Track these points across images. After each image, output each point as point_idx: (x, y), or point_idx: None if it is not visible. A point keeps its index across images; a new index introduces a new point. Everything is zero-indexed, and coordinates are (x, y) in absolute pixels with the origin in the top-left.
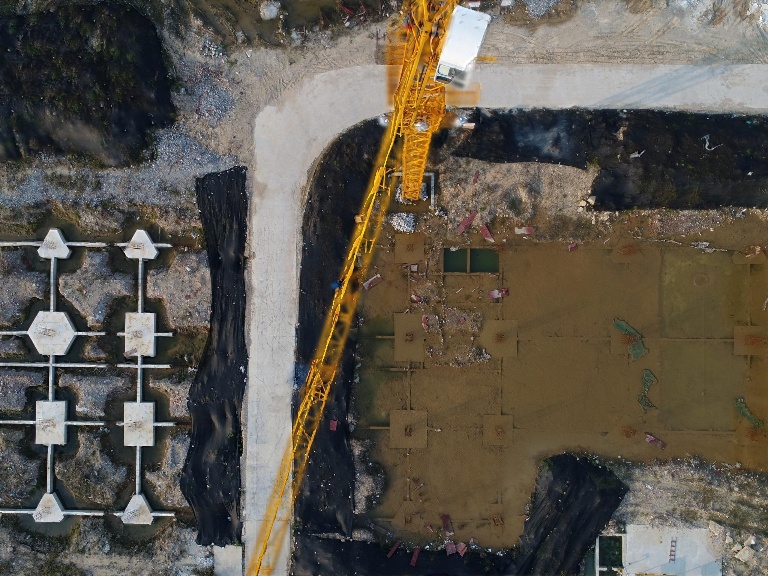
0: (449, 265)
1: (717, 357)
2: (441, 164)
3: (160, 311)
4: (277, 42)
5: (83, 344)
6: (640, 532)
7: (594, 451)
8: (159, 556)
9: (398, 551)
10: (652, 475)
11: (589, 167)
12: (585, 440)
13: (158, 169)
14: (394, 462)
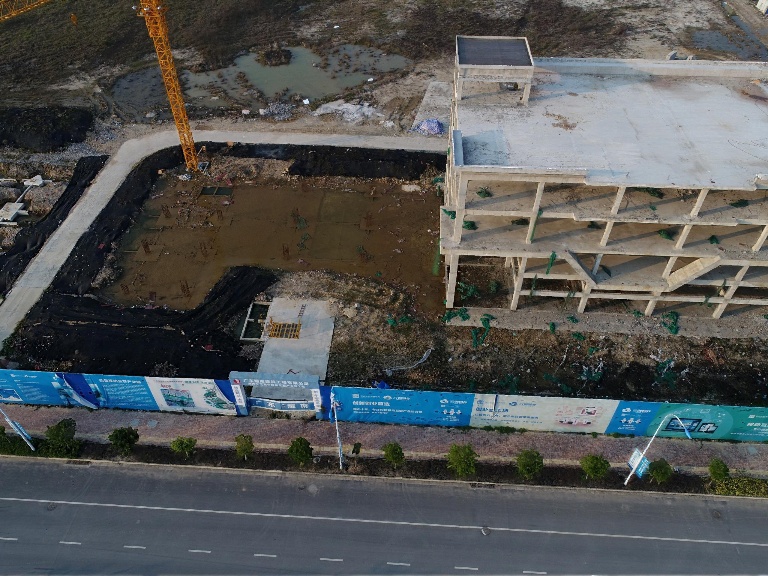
0: (204, 192)
1: (349, 230)
2: (213, 158)
3: (28, 206)
4: (150, 123)
5: None
6: (282, 301)
7: (263, 266)
8: None
9: None
10: (297, 275)
11: (290, 160)
12: (259, 261)
13: (64, 154)
14: (132, 267)
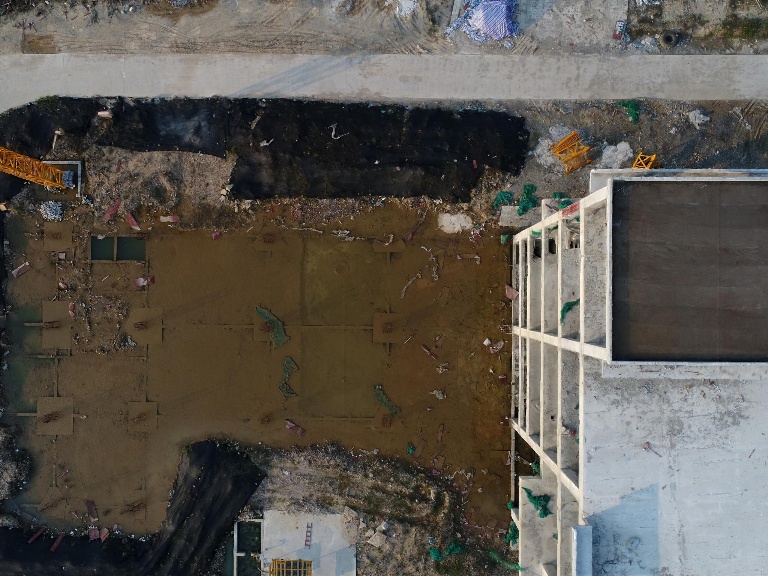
0: (96, 253)
1: (357, 344)
2: (85, 153)
3: None
4: None
5: None
6: (277, 518)
7: (236, 438)
8: None
9: (42, 537)
10: (290, 461)
11: (228, 156)
12: (227, 427)
13: None
14: (41, 448)
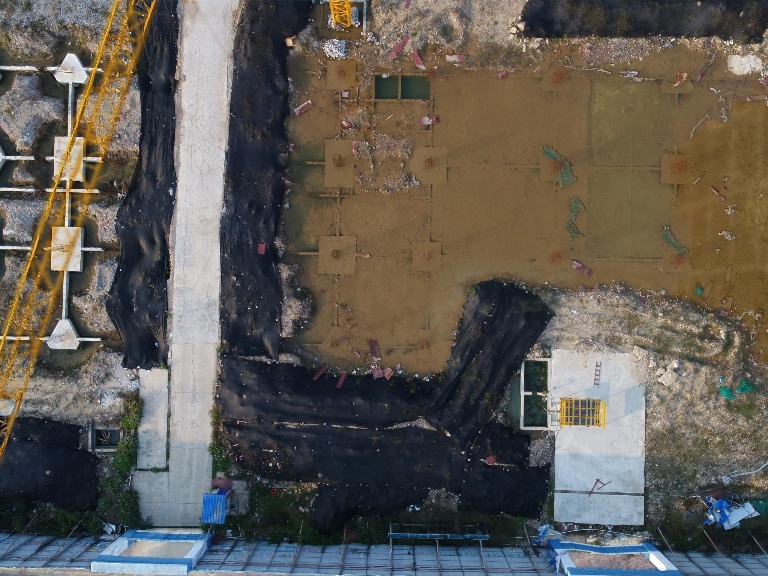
0: (380, 92)
1: (644, 185)
2: None
3: (90, 137)
4: None
5: (12, 169)
6: (565, 357)
7: (521, 278)
8: (84, 379)
9: (325, 375)
10: (578, 301)
11: None
12: (513, 267)
13: None
14: (322, 288)
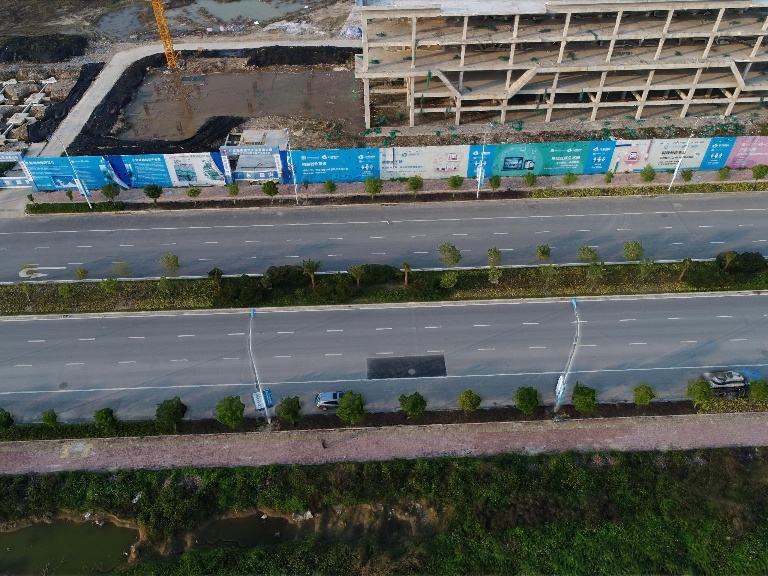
0: None
1: (295, 94)
2: (188, 59)
3: None
4: None
5: None
6: None
7: None
8: None
9: None
10: None
11: (247, 57)
12: (231, 114)
13: (69, 63)
14: (137, 122)
